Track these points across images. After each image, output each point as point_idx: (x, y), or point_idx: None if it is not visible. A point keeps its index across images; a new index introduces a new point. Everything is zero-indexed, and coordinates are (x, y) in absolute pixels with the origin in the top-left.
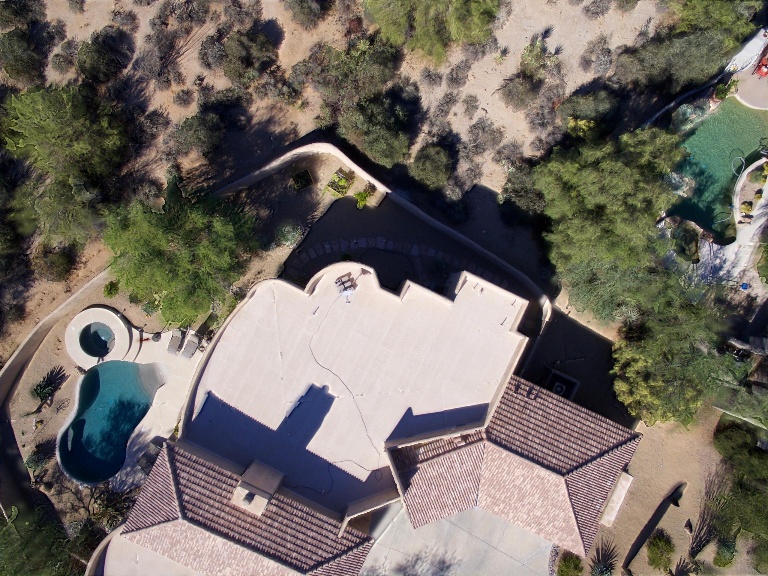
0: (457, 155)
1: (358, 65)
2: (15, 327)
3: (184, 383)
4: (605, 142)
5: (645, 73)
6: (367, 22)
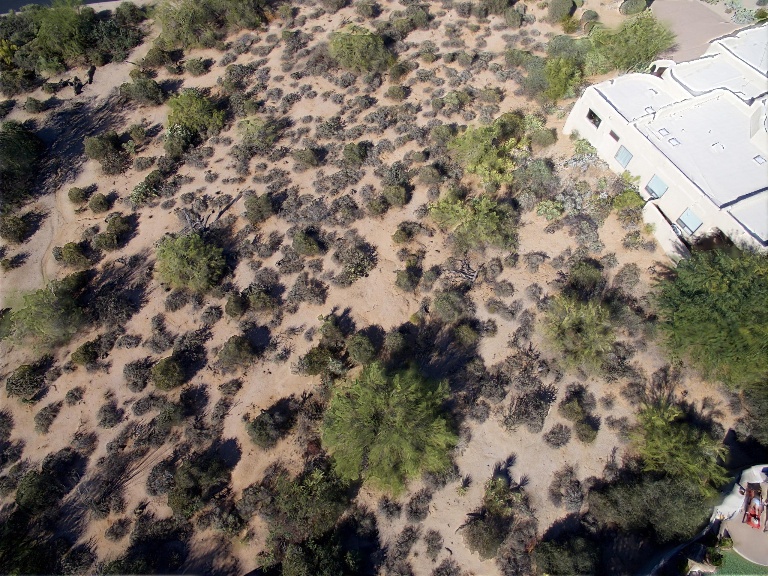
0: None
1: (311, 495)
2: None
3: None
4: None
5: (622, 518)
6: (326, 444)
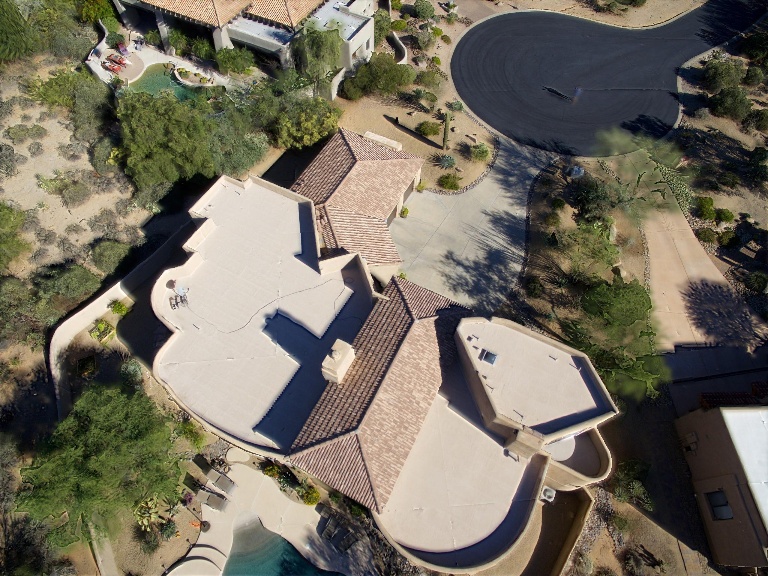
0: None
1: None
2: None
3: (262, 495)
4: None
5: (93, 123)
6: None
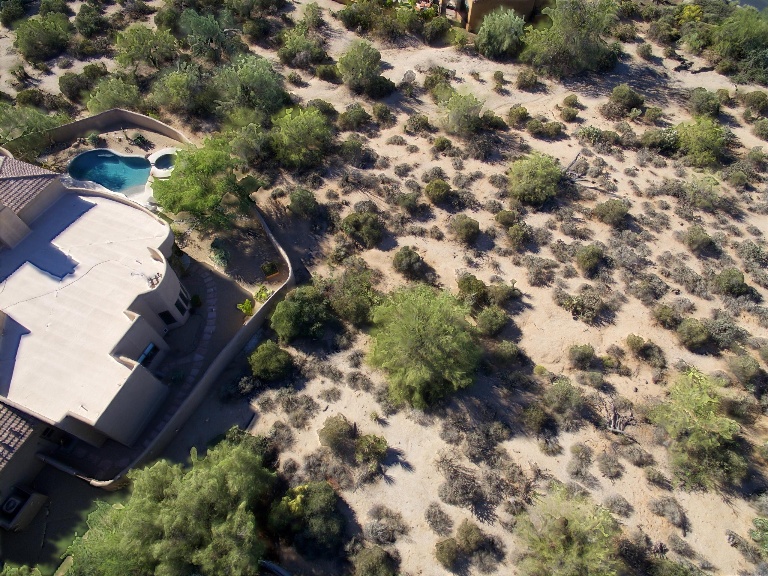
0: (284, 386)
1: None
2: (188, 129)
3: None
4: (288, 544)
5: None
6: None
